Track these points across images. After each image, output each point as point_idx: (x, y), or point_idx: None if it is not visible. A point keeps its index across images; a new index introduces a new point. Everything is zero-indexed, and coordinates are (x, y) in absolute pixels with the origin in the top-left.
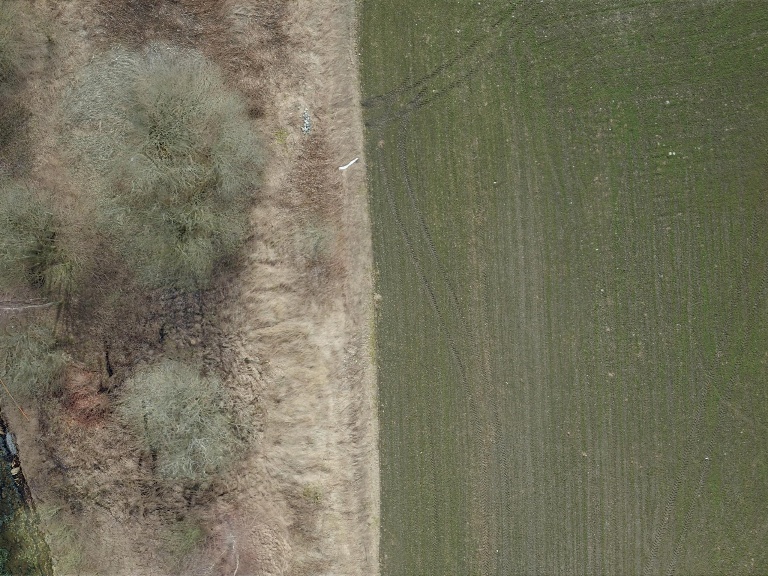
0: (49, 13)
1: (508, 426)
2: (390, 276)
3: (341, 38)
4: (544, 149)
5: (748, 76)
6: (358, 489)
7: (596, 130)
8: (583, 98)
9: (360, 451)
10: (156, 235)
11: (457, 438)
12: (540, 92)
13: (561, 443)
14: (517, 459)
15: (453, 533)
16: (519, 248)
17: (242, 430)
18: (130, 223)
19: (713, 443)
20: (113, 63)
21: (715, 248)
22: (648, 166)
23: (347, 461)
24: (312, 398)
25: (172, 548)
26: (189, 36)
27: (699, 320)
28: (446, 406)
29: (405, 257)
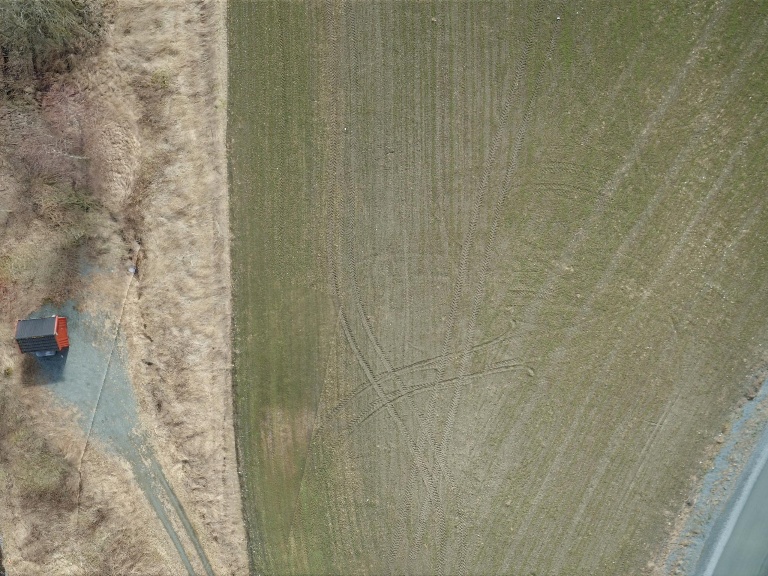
0: None
1: None
2: None
3: None
4: None
5: None
6: (206, 71)
7: None
8: None
9: (208, 30)
10: None
11: (306, 12)
12: None
13: (410, 10)
14: (366, 31)
15: (301, 113)
16: None
17: (93, 23)
18: None
19: (565, 2)
20: None
21: None
22: None
23: (194, 41)
24: None
25: (23, 155)
26: None
27: None
28: None
29: None
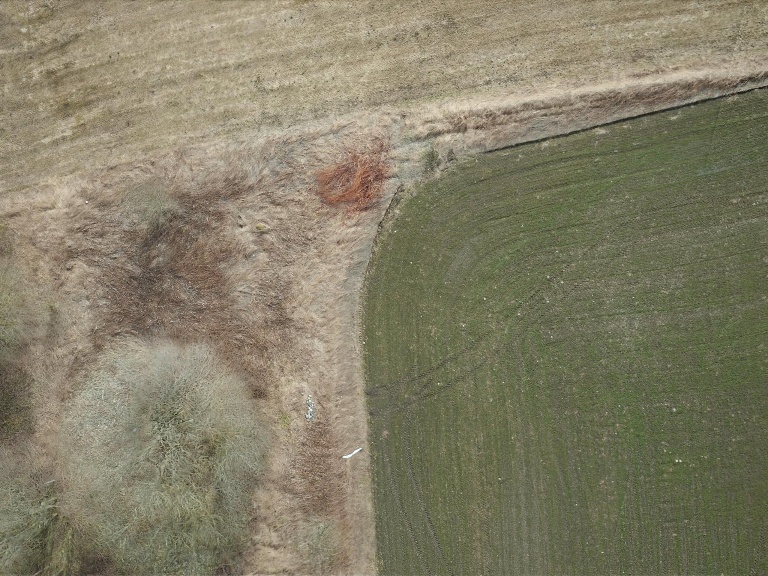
0: (52, 283)
1: None
2: (394, 567)
3: (345, 326)
4: (549, 449)
5: (755, 388)
6: None
7: (602, 434)
8: (589, 401)
9: None
10: None
11: None
12: (546, 392)
13: None
14: None
15: None
16: (524, 546)
17: None
18: (132, 493)
19: None
20: (116, 334)
21: (722, 557)
22: (654, 472)
23: None
24: None
25: None
26: (193, 310)
27: None
28: None
29: (409, 549)
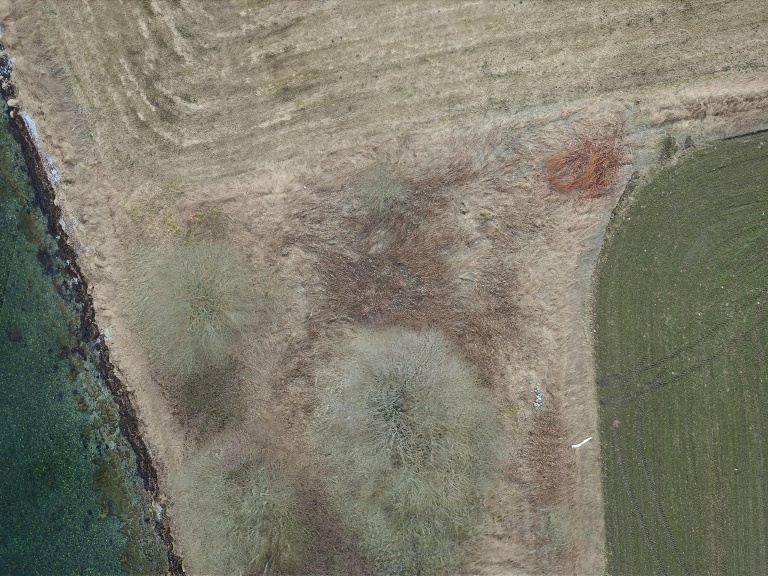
0: (267, 268)
1: None
2: (624, 558)
3: (576, 314)
4: None
5: None
6: None
7: None
8: None
9: None
10: (373, 495)
11: None
12: None
13: None
14: None
15: None
16: (761, 537)
17: None
18: (345, 482)
19: None
20: (331, 321)
21: None
22: None
23: None
24: None
25: None
26: (411, 297)
27: None
28: None
29: (640, 539)
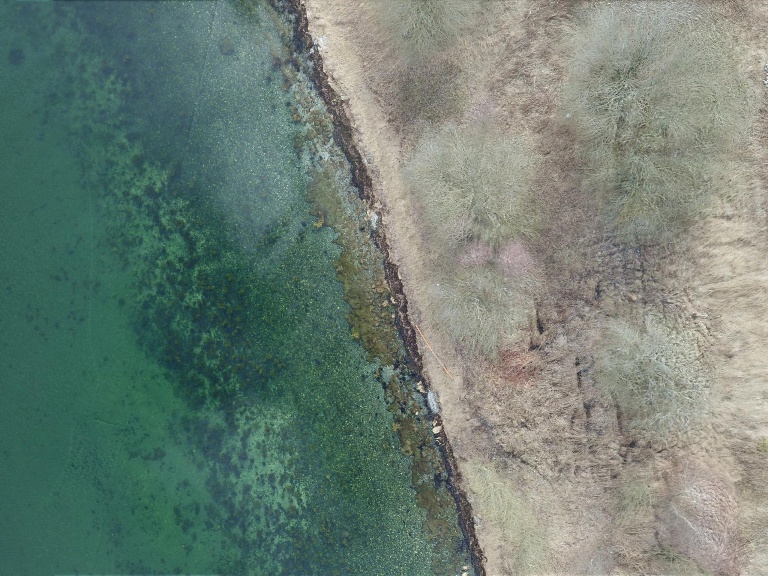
0: None
1: None
2: None
3: None
4: None
5: None
6: None
7: None
8: None
9: None
10: (593, 191)
11: None
12: None
13: None
14: None
15: None
16: None
17: (686, 386)
18: (565, 179)
19: None
20: (551, 19)
21: None
22: None
23: None
24: None
25: (604, 506)
26: None
27: None
28: None
29: None
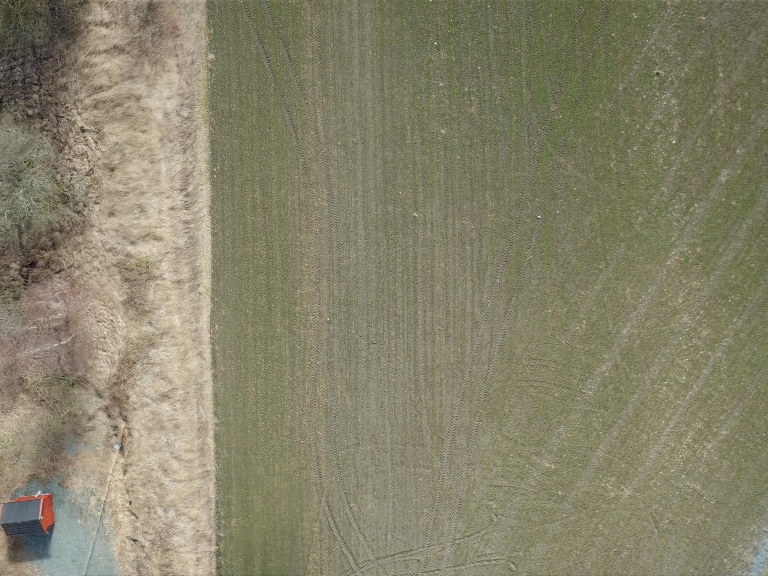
0: None
1: (340, 188)
2: (223, 35)
3: None
4: None
5: None
6: (189, 257)
7: None
8: None
9: (191, 217)
10: None
11: (289, 202)
12: None
13: (392, 204)
14: (349, 222)
15: (284, 301)
16: (353, 2)
17: (78, 203)
18: None
19: (546, 201)
20: None
21: None
22: None
23: (178, 228)
24: (144, 164)
25: (9, 329)
26: None
27: (533, 72)
28: (278, 169)
29: (239, 15)
